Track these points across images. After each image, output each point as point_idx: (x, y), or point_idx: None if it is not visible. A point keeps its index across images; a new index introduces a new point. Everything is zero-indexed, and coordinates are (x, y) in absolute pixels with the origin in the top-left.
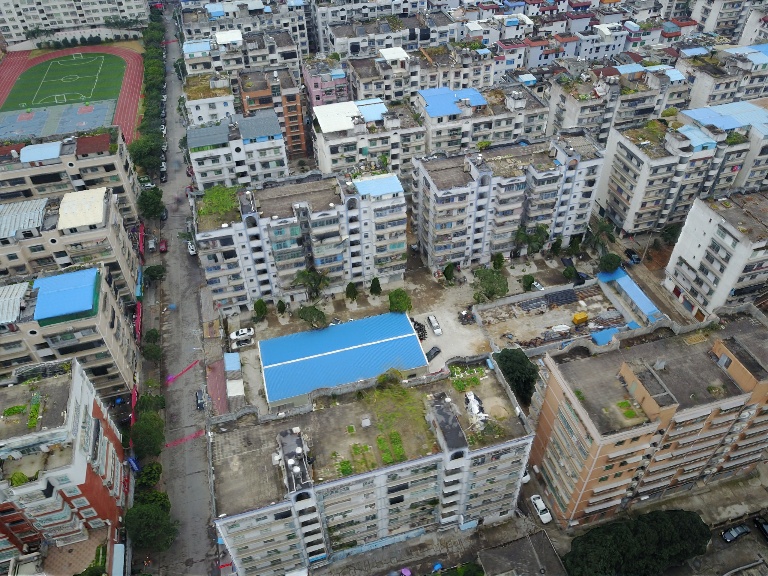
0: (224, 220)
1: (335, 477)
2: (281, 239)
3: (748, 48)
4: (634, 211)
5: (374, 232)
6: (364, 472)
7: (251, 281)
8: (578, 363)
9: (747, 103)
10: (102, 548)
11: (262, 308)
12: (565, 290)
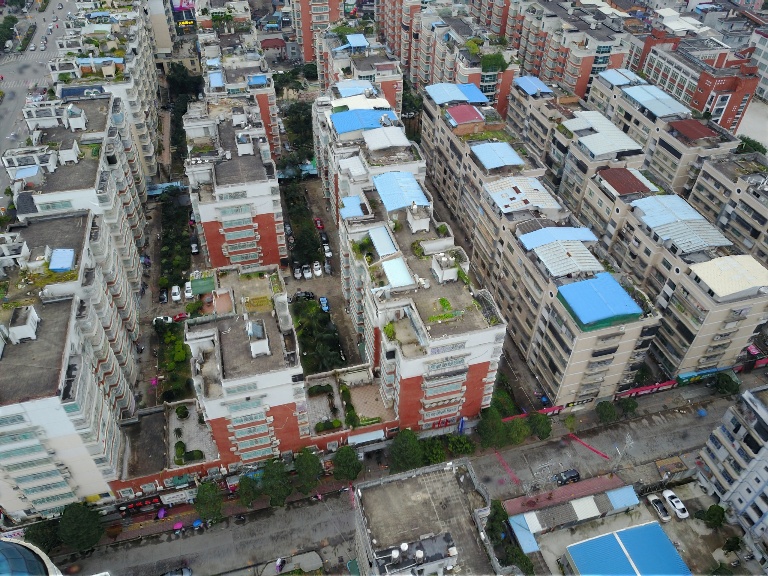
0: None
1: None
2: None
3: None
4: None
5: None
6: None
7: (748, 490)
8: None
9: None
10: (378, 420)
11: (714, 516)
12: None
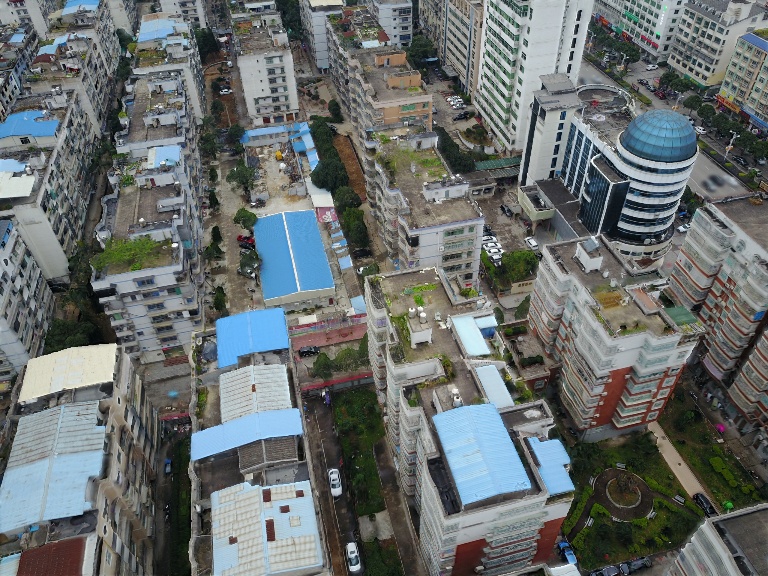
0: (159, 252)
1: None
2: (189, 232)
3: (69, 8)
4: (198, 106)
5: (190, 193)
6: (447, 171)
7: None
8: (380, 98)
9: (146, 22)
10: None
11: None
12: (248, 159)
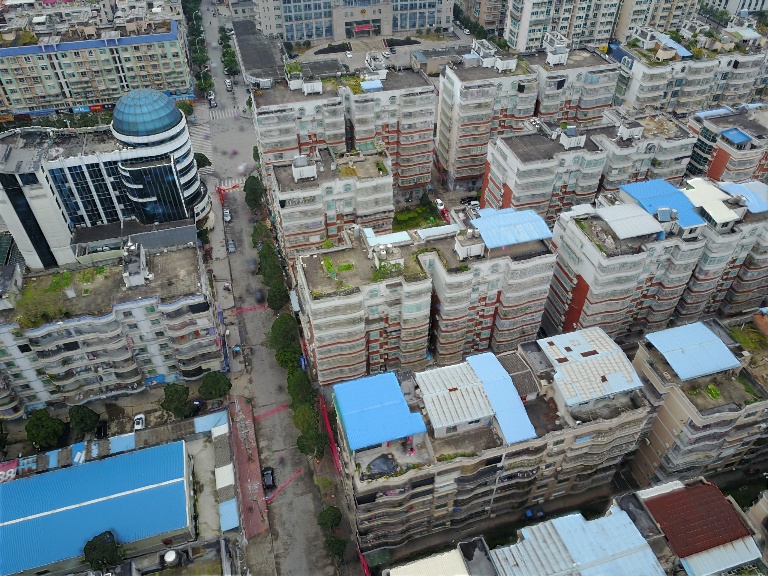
0: None
1: (110, 266)
2: None
3: None
4: None
5: None
6: None
7: None
8: None
9: None
10: None
11: None
12: None
